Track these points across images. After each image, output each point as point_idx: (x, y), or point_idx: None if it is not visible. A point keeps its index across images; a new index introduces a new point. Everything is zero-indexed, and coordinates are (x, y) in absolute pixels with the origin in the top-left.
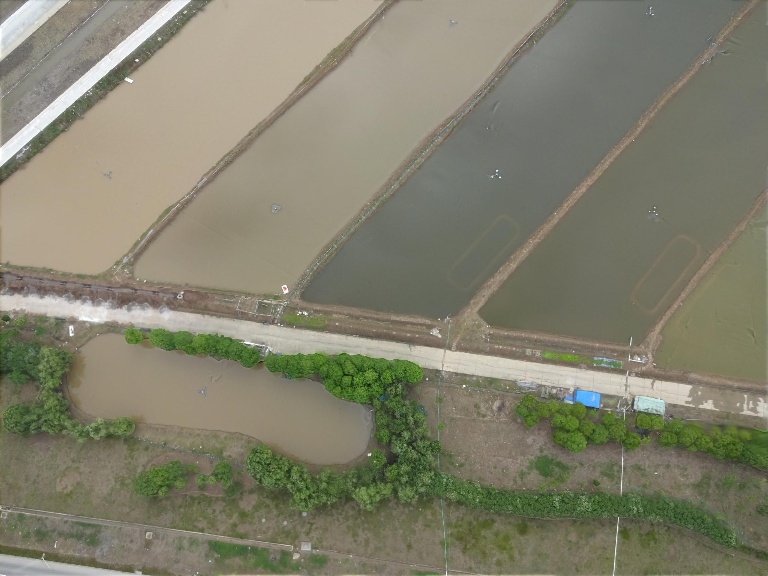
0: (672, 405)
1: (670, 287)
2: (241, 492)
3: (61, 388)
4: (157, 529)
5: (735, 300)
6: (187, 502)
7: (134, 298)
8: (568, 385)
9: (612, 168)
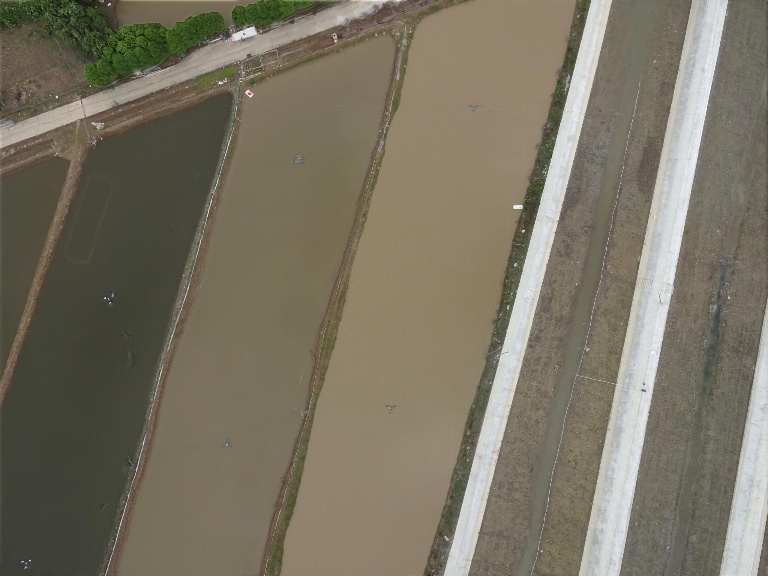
0: None
1: None
2: None
3: None
4: None
5: None
6: None
7: (376, 16)
8: None
9: (2, 361)
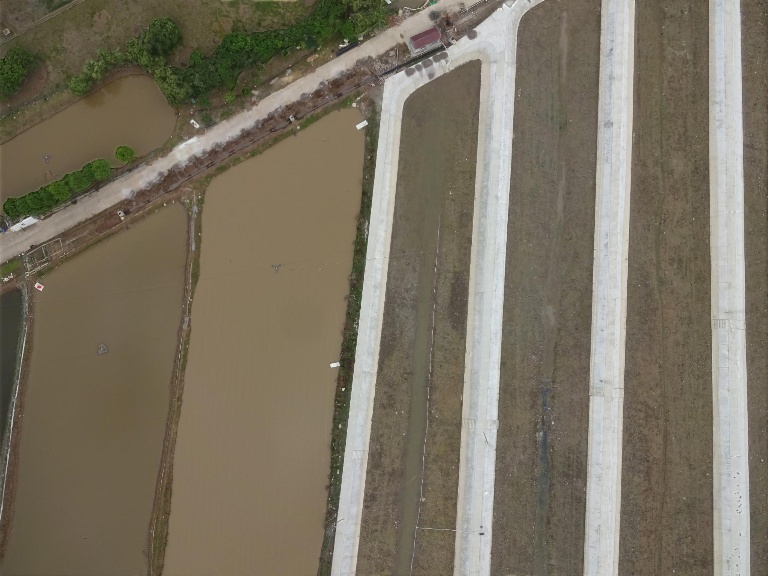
0: None
1: None
2: None
3: None
4: (5, 40)
5: None
6: None
7: (161, 185)
8: None
9: None
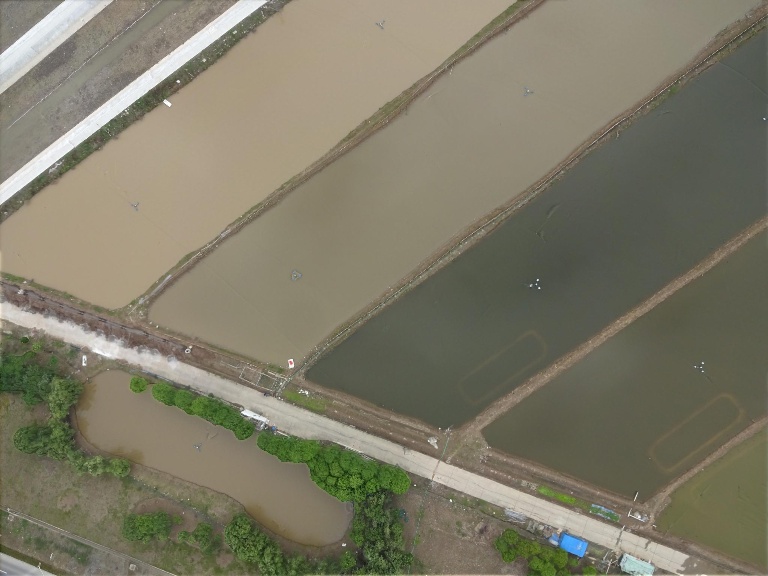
0: (662, 570)
1: (696, 449)
2: (219, 549)
3: (68, 418)
4: (140, 563)
5: (765, 479)
6: (169, 546)
7: (145, 342)
8: (557, 525)
9: (668, 303)
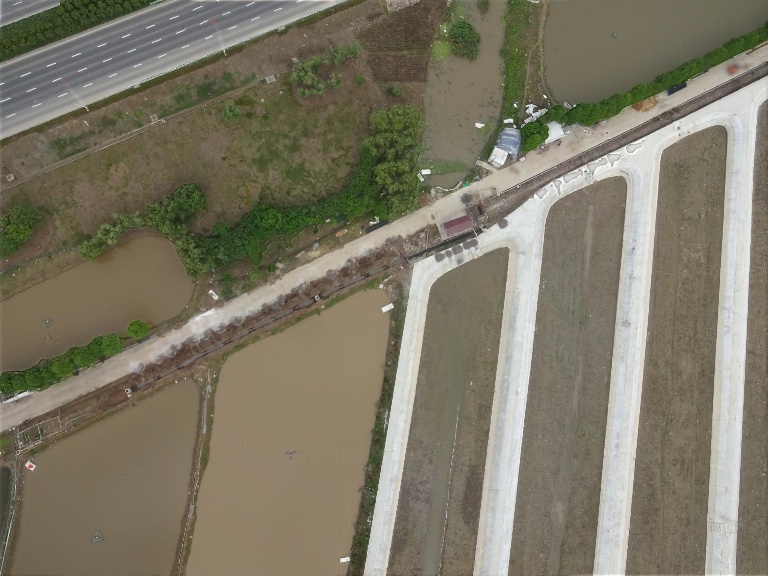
0: None
1: None
2: None
3: None
4: (8, 186)
5: None
6: None
7: (174, 361)
8: None
9: None
